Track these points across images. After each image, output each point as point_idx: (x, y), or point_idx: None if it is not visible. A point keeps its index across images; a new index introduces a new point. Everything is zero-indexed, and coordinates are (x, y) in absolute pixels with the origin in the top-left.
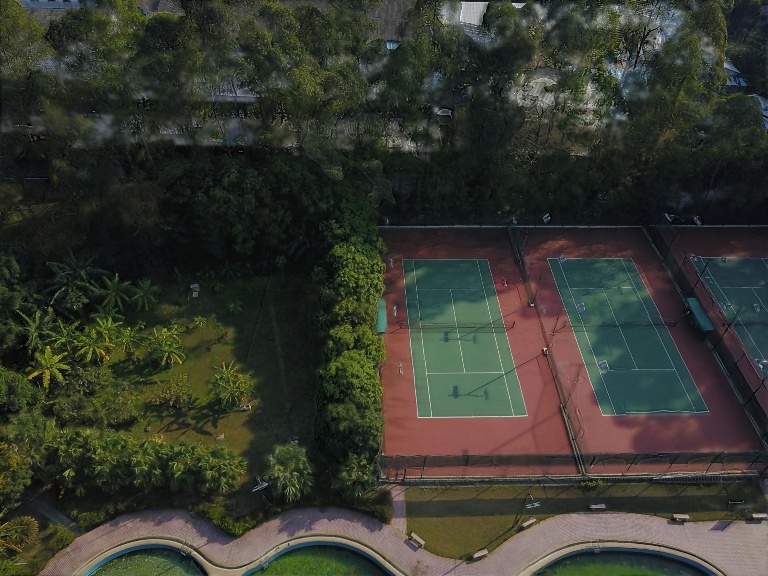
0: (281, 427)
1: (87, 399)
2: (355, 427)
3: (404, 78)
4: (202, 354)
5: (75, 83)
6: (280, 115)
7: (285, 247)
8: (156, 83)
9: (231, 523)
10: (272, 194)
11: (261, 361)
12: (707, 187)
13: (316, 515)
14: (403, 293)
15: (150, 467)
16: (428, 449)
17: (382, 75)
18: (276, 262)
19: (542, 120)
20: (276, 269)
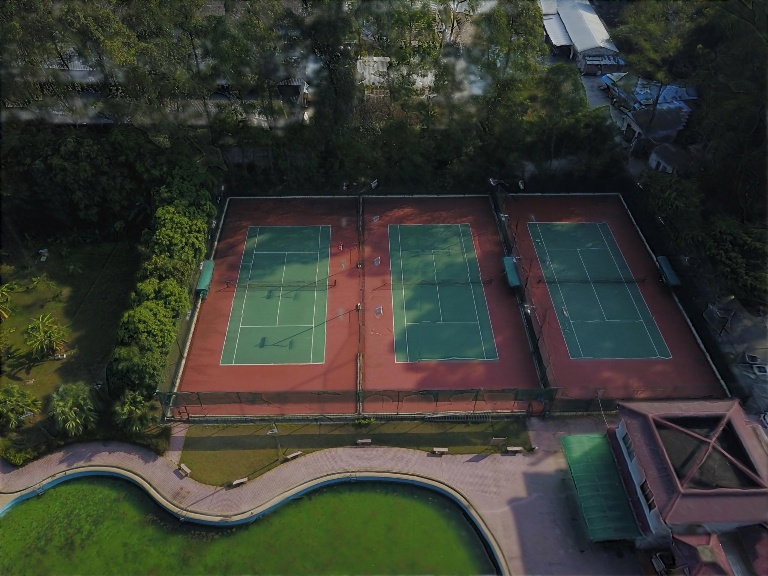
0: (89, 373)
1: None
2: (131, 366)
3: (223, 50)
4: (34, 311)
5: None
6: (115, 88)
7: (127, 213)
8: None
9: (13, 454)
10: (109, 162)
11: (88, 316)
12: (549, 156)
13: (98, 448)
14: (240, 256)
15: None
16: None
17: (208, 49)
18: (115, 227)
19: None
20: None
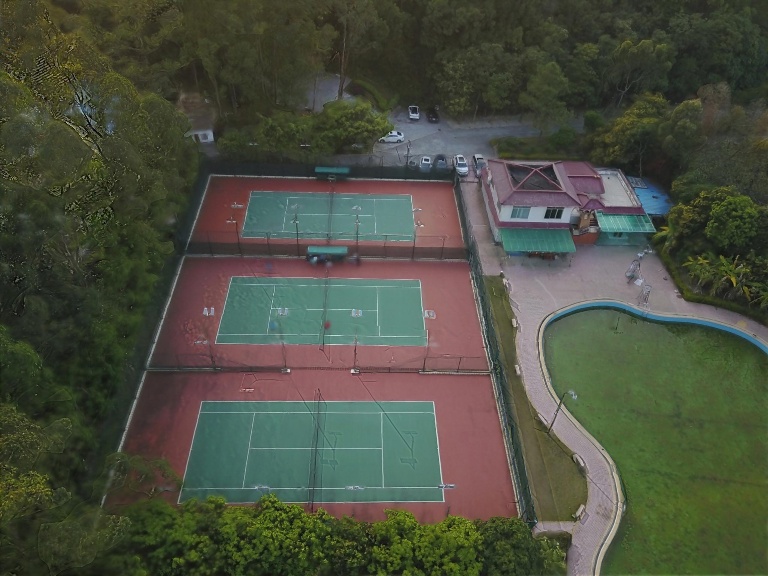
0: None
1: None
2: (525, 542)
3: (19, 353)
4: None
5: None
6: None
7: None
8: None
9: None
10: None
11: None
12: None
13: None
14: None
15: None
16: (482, 494)
17: None
18: None
19: None
20: None
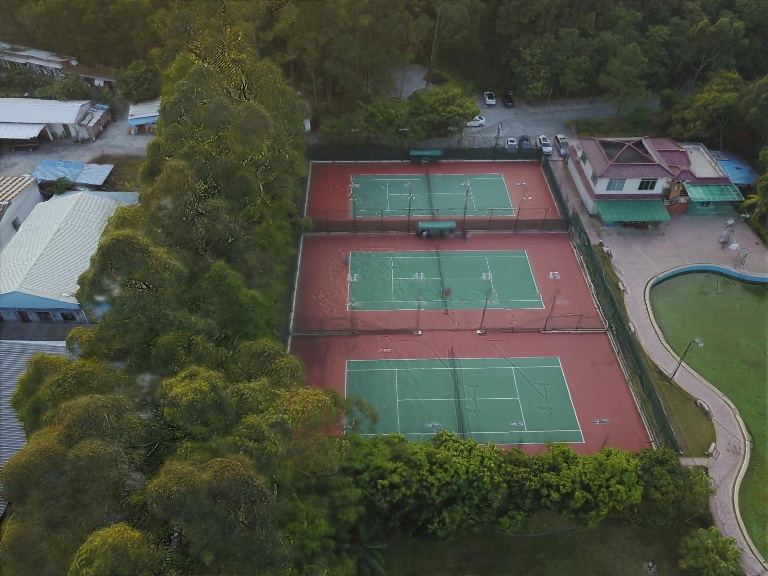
0: None
1: None
2: (679, 468)
3: (256, 297)
4: None
5: None
6: None
7: None
8: None
9: None
10: (336, 569)
11: None
12: None
13: None
14: None
15: None
16: (619, 436)
17: (217, 329)
18: None
19: None
20: None
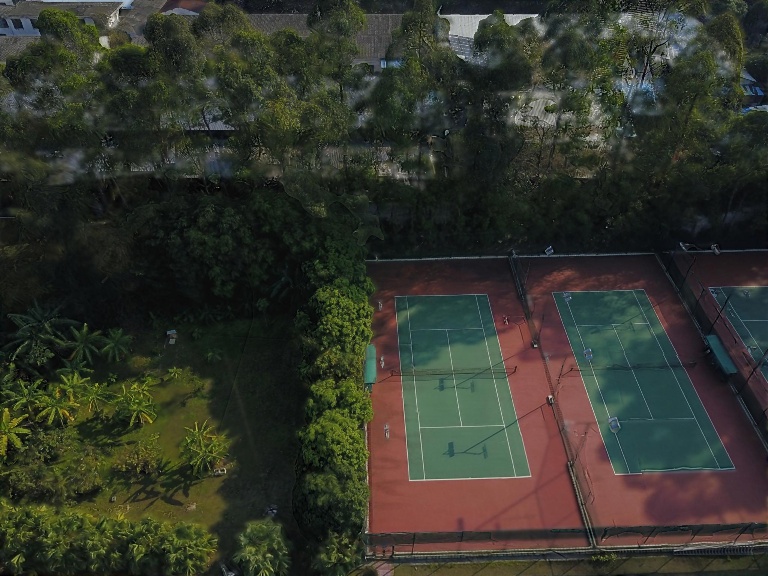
0: (258, 494)
1: (47, 467)
2: (335, 502)
3: (389, 106)
4: (176, 410)
5: (35, 122)
6: (257, 148)
7: (267, 289)
8: (119, 121)
9: None
10: (251, 233)
11: (239, 417)
12: (725, 209)
13: None
14: (395, 335)
15: (108, 550)
16: (420, 518)
17: (366, 102)
18: (257, 306)
19: (543, 142)
20: (259, 311)
